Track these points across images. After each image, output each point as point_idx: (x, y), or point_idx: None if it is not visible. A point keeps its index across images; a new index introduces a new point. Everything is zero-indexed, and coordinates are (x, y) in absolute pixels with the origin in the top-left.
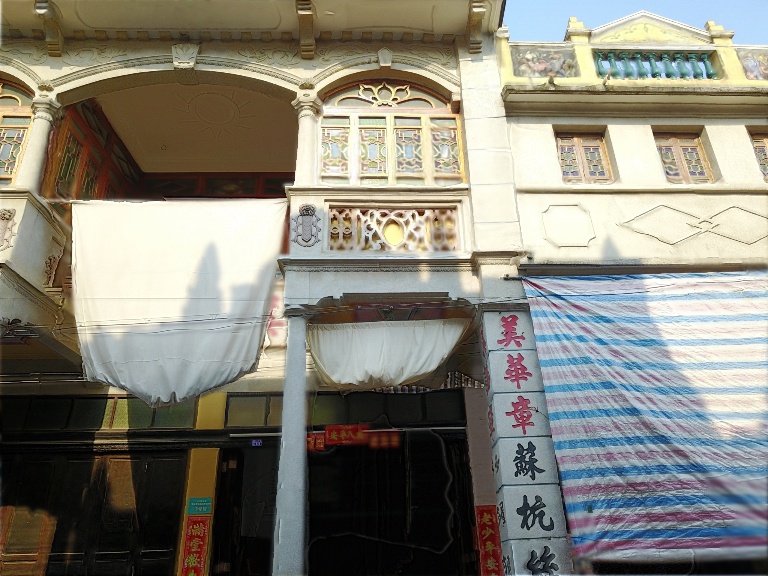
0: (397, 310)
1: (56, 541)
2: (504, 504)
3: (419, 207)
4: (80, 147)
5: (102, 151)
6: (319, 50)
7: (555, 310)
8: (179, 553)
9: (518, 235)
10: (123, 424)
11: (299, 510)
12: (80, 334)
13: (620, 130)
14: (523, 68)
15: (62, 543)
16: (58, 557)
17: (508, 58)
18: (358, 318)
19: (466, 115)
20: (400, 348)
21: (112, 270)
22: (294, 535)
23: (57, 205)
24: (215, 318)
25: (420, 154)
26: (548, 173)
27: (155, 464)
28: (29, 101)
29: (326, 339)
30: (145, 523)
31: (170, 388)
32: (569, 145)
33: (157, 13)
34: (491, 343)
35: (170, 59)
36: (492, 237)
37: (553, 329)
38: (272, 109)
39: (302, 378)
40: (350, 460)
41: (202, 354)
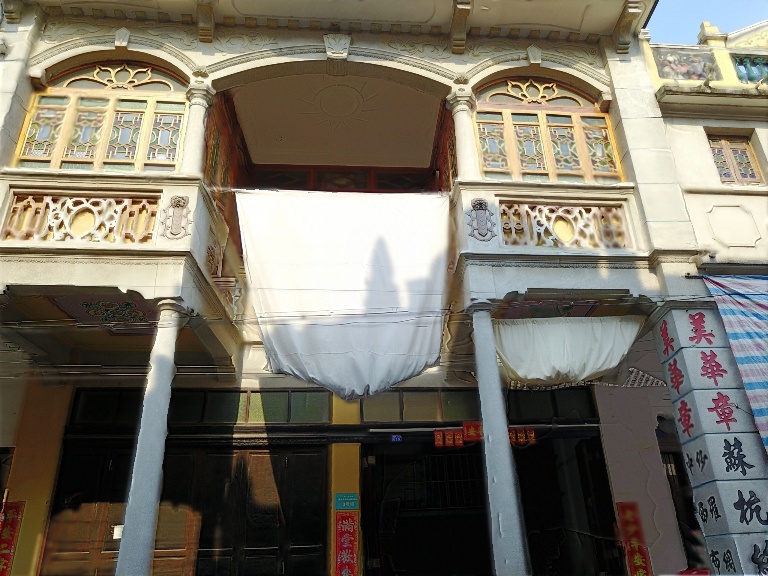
0: (577, 306)
1: (203, 536)
2: (720, 499)
3: (586, 204)
4: (220, 135)
5: (231, 140)
6: (468, 45)
7: (742, 309)
8: (330, 549)
9: (692, 234)
10: (259, 418)
11: (517, 504)
12: (261, 325)
13: (767, 134)
14: (667, 70)
15: (209, 539)
16: (207, 553)
17: (652, 60)
18: (537, 313)
19: (623, 114)
20: (581, 344)
21: (287, 261)
22: (516, 529)
23: (220, 194)
24: (396, 311)
25: (576, 152)
26: (706, 174)
27: (295, 459)
28: (180, 87)
29: (508, 334)
30: (291, 518)
31: (364, 381)
32: (718, 147)
33: (313, 2)
34: (683, 340)
35: (322, 49)
36: (667, 236)
37: (744, 327)
38: (397, 103)
39: (498, 372)
40: (549, 455)
41: (388, 347)
